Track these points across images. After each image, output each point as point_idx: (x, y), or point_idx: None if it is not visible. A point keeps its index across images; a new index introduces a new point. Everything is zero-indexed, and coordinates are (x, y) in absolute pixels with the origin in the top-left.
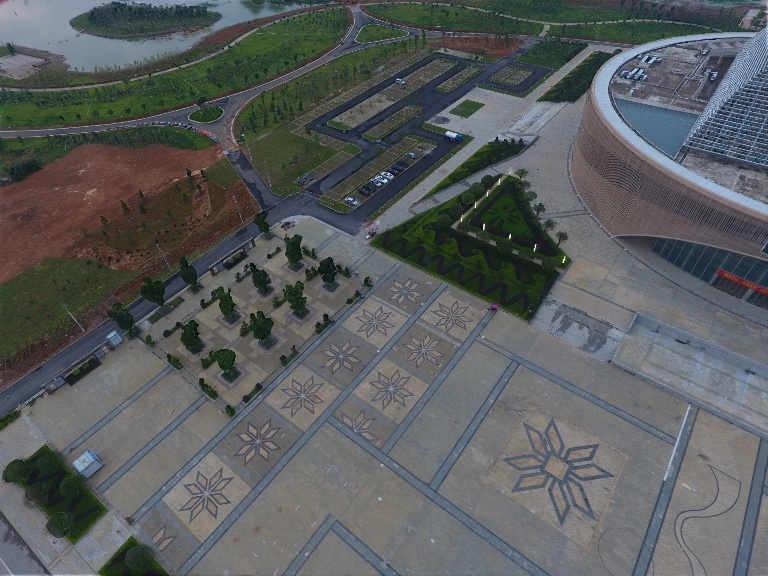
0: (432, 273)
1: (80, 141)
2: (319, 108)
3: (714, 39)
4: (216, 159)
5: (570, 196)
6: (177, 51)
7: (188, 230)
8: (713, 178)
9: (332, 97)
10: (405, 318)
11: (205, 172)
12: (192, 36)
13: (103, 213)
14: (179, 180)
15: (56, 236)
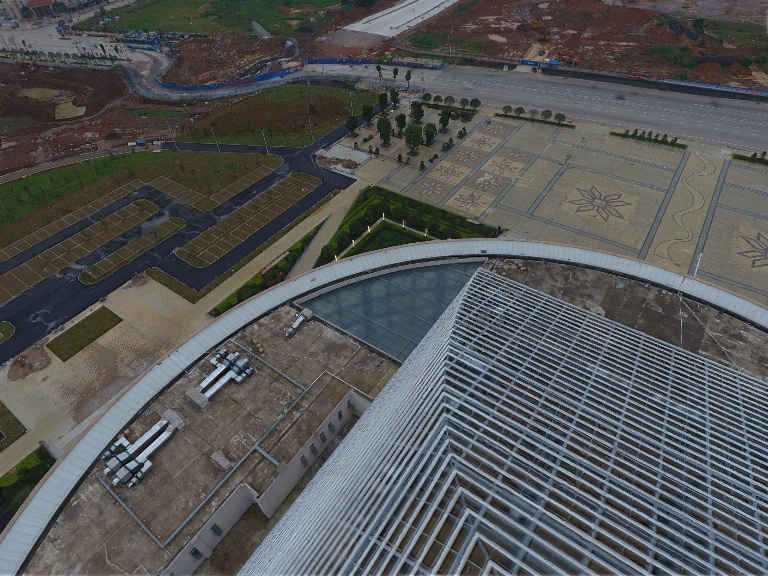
0: None
1: None
2: None
3: None
4: None
5: None
6: None
7: None
8: None
9: None
10: None
11: None
12: None
13: None
14: None
15: None
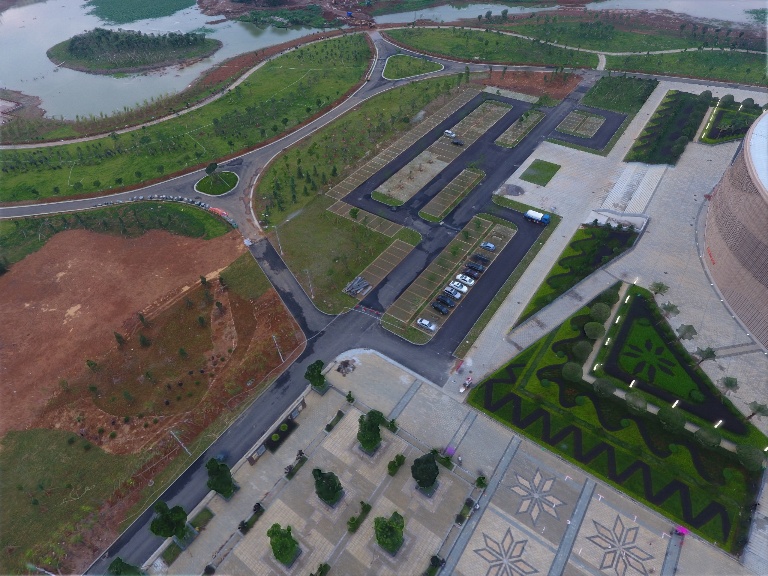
0: (568, 458)
1: (58, 225)
2: (357, 173)
3: None
4: (236, 253)
5: (725, 318)
6: (174, 93)
7: (209, 377)
8: None
9: (370, 156)
10: (550, 553)
11: (224, 275)
12: (190, 70)
13: (90, 347)
14: (190, 288)
15: (25, 389)
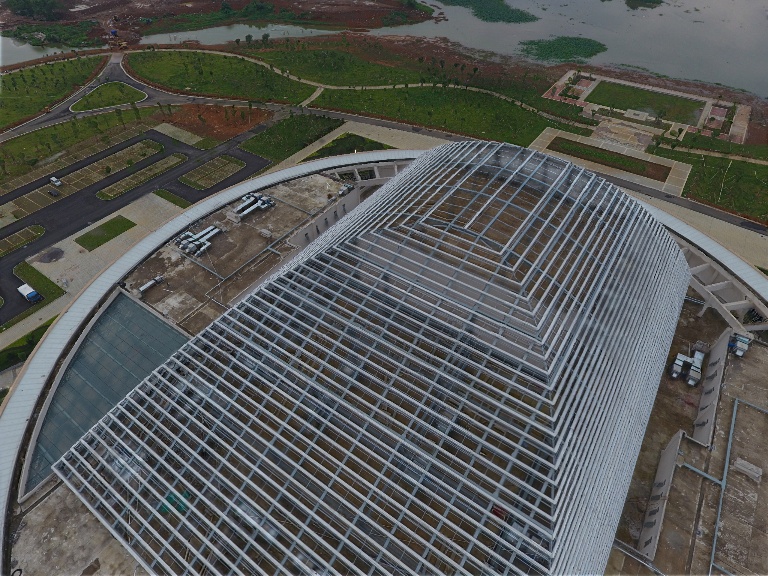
0: None
1: None
2: None
3: (384, 161)
4: None
5: None
6: None
7: None
8: (32, 574)
9: None
10: None
11: None
12: None
13: None
14: None
15: None
